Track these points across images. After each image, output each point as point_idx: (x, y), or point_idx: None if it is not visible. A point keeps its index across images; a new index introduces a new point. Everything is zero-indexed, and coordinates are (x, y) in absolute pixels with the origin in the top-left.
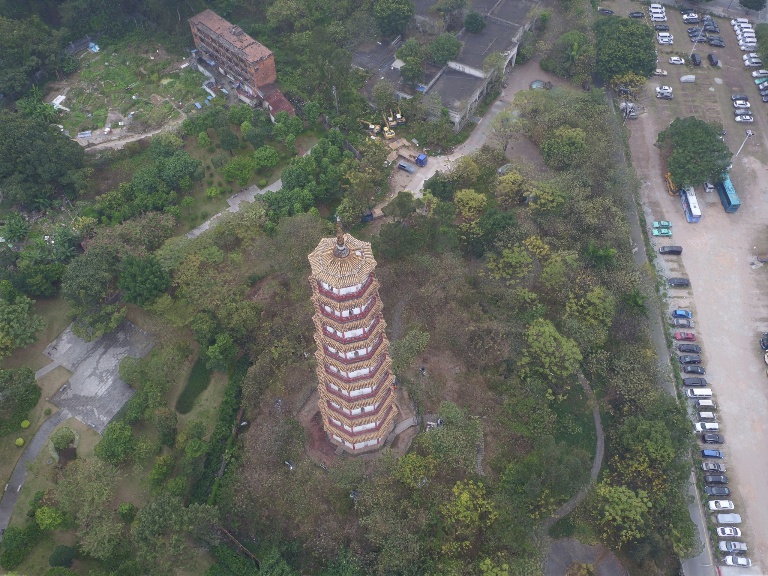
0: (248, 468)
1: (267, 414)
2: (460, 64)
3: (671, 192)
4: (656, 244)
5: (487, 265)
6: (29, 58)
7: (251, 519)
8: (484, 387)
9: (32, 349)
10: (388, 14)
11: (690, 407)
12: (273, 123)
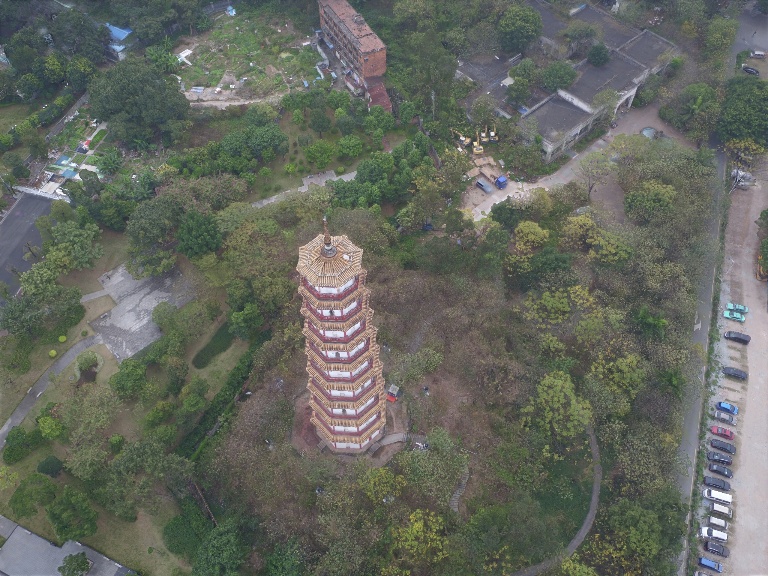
0: (234, 436)
1: (266, 390)
2: (570, 94)
3: (759, 276)
4: (723, 327)
5: (525, 303)
6: (168, 10)
7: (223, 484)
8: (484, 424)
9: (90, 273)
10: (511, 30)
11: (703, 508)
12: (369, 115)
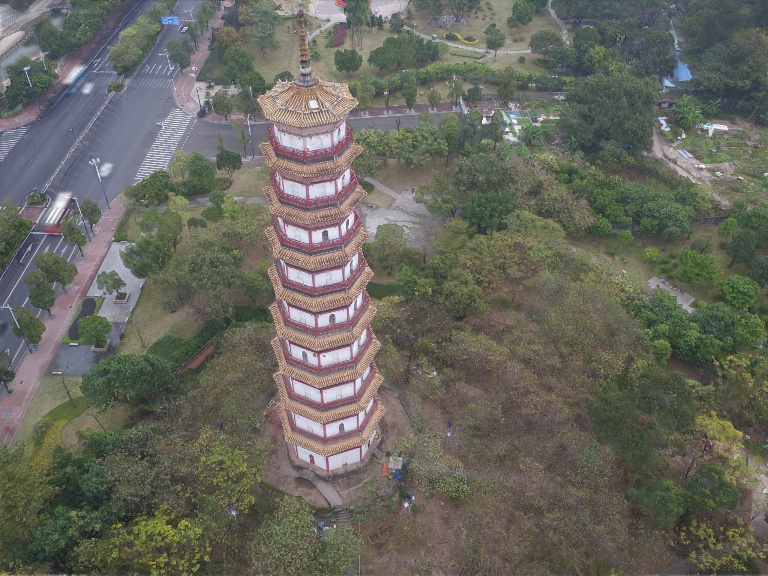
0: None
1: None
2: None
3: None
4: None
5: None
6: None
7: None
8: None
9: (409, 179)
10: None
11: None
12: None
